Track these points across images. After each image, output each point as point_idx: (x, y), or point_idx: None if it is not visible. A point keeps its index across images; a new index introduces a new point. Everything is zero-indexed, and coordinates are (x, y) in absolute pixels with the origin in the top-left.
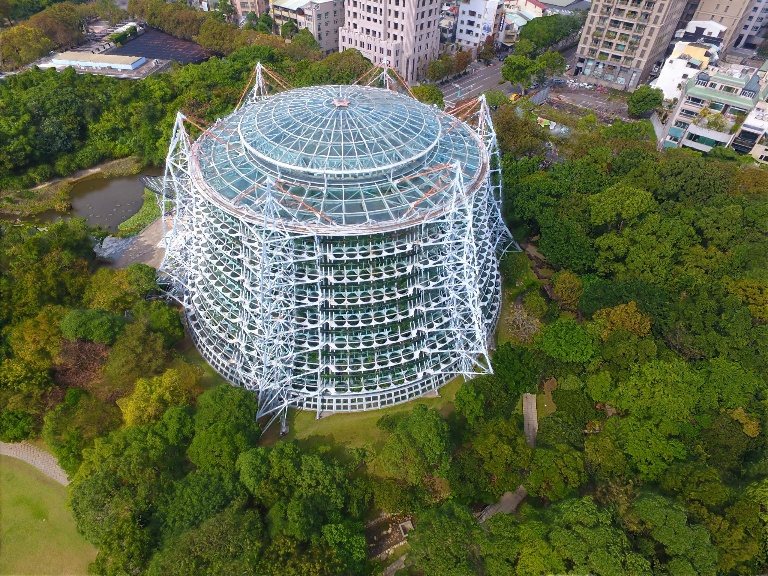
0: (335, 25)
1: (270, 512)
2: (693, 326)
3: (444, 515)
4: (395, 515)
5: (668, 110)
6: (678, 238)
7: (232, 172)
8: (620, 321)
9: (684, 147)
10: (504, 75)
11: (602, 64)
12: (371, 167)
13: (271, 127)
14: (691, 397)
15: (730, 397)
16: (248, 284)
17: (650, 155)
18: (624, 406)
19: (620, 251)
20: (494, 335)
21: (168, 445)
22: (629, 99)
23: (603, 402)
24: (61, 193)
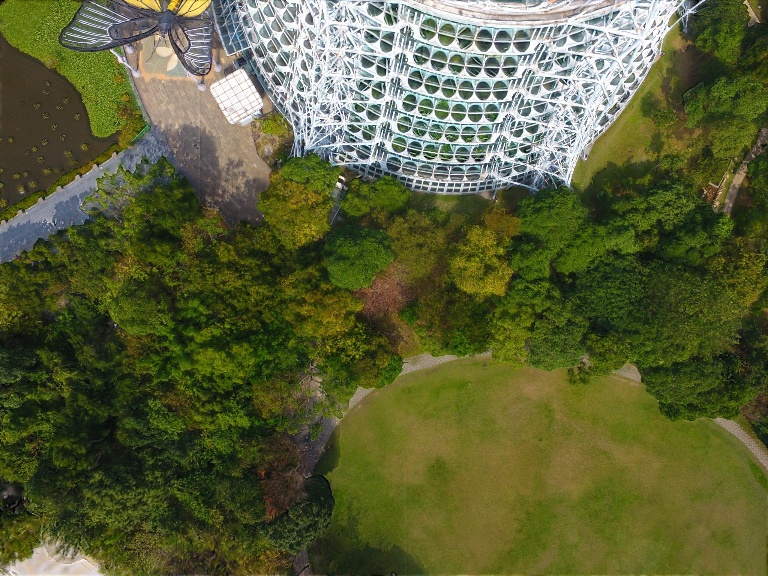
0: None
1: (670, 253)
2: None
3: None
4: None
5: None
6: None
7: None
8: None
9: None
10: None
11: None
12: None
13: None
14: None
15: None
16: None
17: None
18: None
19: None
20: None
21: None
22: None
23: None
24: None
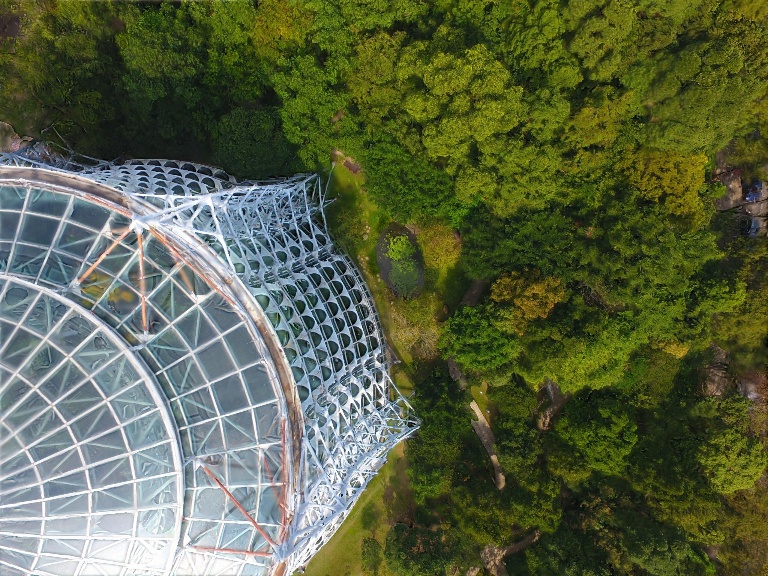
0: None
1: None
2: None
3: None
4: None
5: None
6: None
7: None
8: (533, 316)
9: None
10: None
11: None
12: None
13: None
14: (626, 356)
15: None
16: None
17: None
18: None
19: (490, 190)
20: (387, 342)
21: None
22: None
23: None
24: None
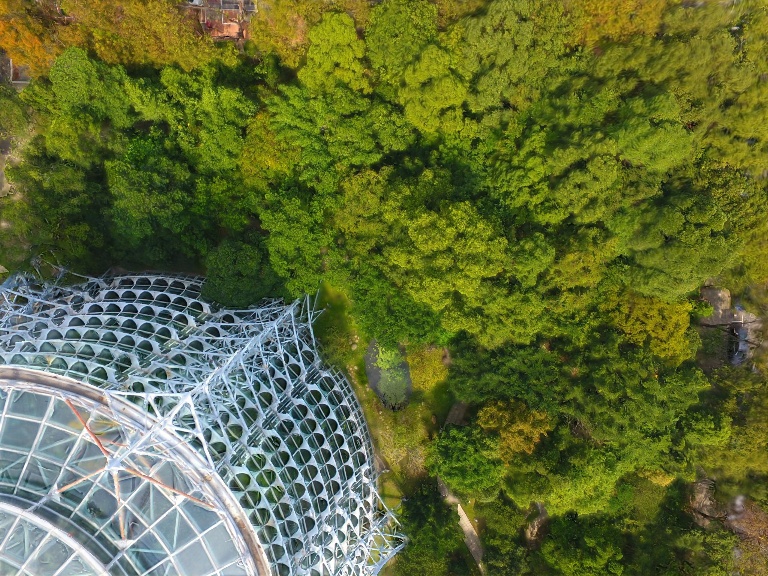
0: None
1: None
2: None
3: None
4: None
5: None
6: None
7: None
8: None
9: None
10: None
11: None
12: None
13: None
14: (611, 485)
15: None
16: None
17: (427, 16)
18: None
19: None
20: (375, 451)
21: None
22: None
23: None
24: None
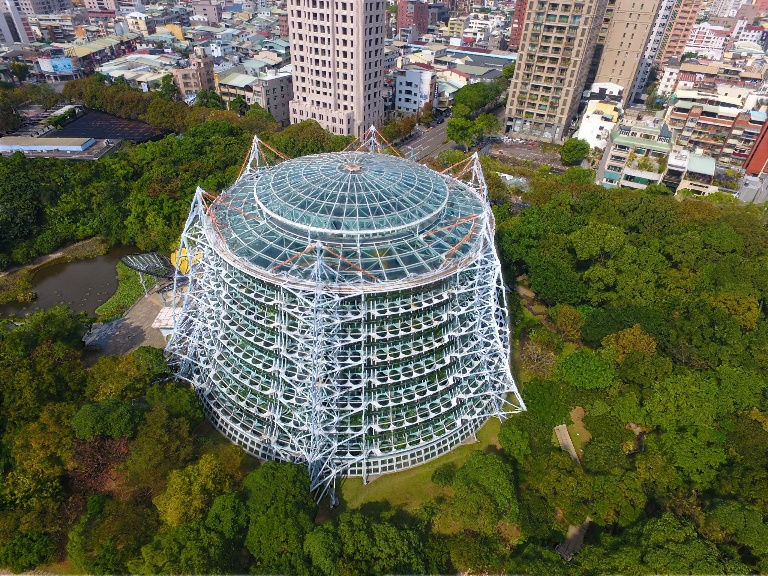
0: (282, 99)
1: None
2: (694, 340)
3: (537, 559)
4: (471, 573)
5: (593, 157)
6: (655, 264)
7: (257, 241)
8: (631, 344)
9: (623, 187)
10: (449, 136)
11: (529, 122)
12: (397, 224)
13: (291, 195)
14: (711, 405)
15: (743, 400)
16: (285, 352)
17: (606, 195)
18: (655, 423)
19: (610, 281)
20: (511, 374)
21: (224, 539)
22: (561, 150)
23: (631, 422)
24: (22, 282)
